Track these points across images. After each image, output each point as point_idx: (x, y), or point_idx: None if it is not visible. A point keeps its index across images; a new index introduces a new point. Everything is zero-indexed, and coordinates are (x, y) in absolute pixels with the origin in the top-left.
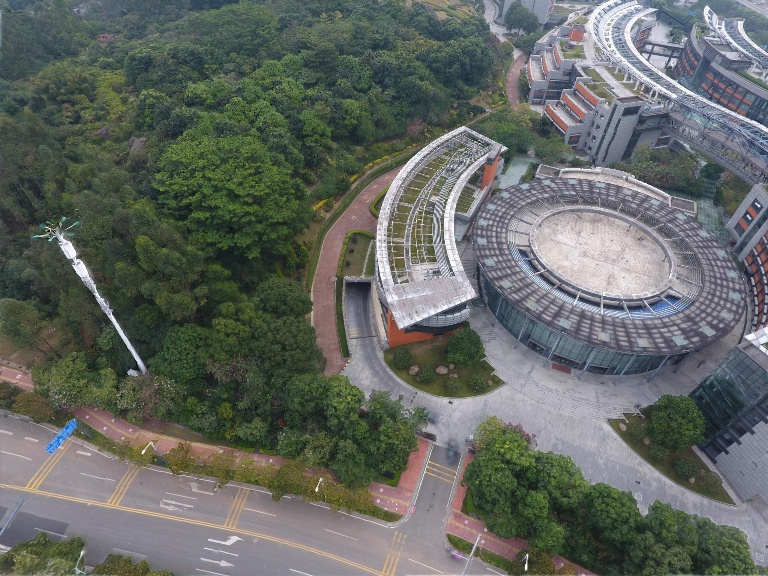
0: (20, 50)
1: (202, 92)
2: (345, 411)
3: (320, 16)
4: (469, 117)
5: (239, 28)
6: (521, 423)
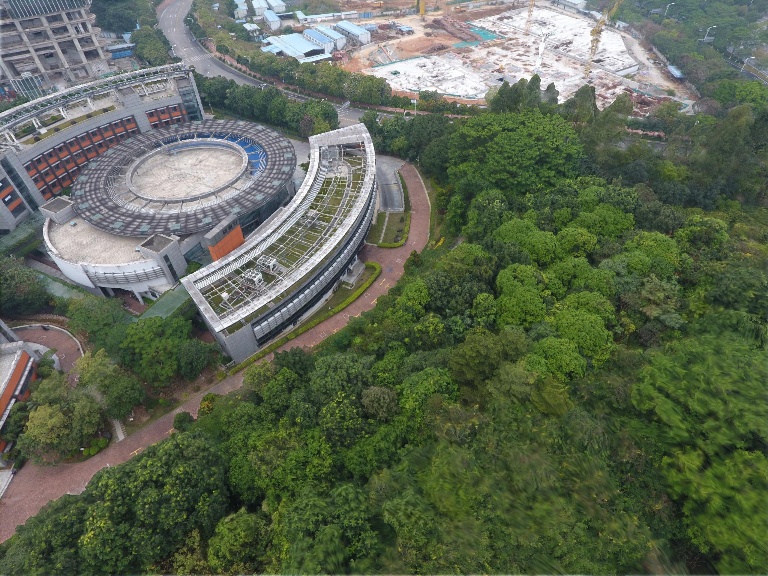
0: None
1: (644, 238)
2: None
3: None
4: None
5: (718, 342)
6: (298, 153)
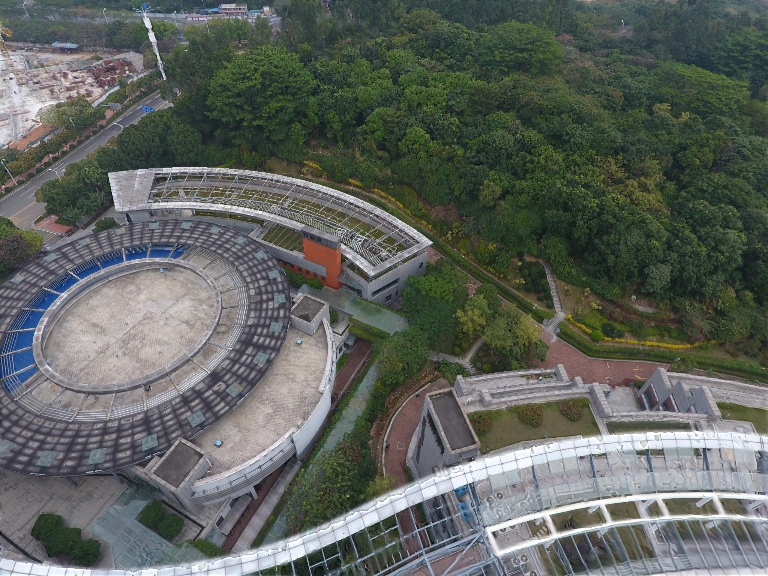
0: (482, 9)
1: (391, 56)
2: (78, 167)
3: (658, 104)
4: None
5: (488, 39)
6: None
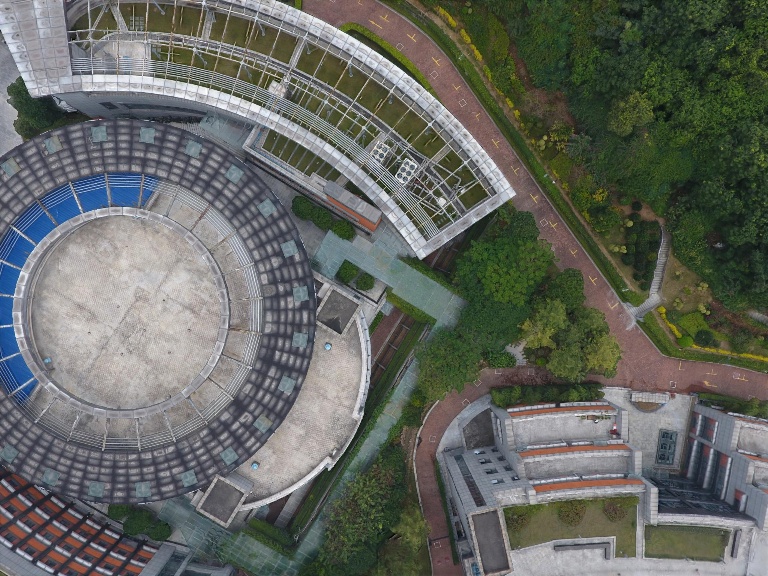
0: None
1: None
2: None
3: None
4: (614, 244)
5: None
6: None
